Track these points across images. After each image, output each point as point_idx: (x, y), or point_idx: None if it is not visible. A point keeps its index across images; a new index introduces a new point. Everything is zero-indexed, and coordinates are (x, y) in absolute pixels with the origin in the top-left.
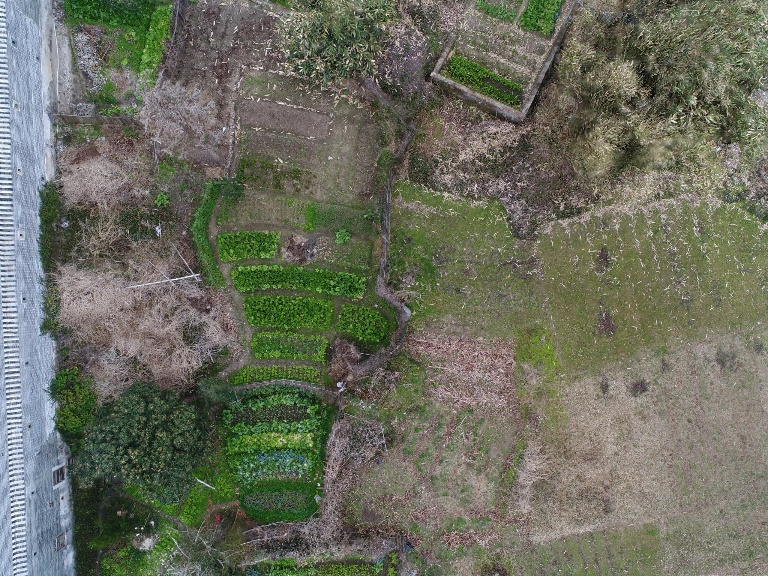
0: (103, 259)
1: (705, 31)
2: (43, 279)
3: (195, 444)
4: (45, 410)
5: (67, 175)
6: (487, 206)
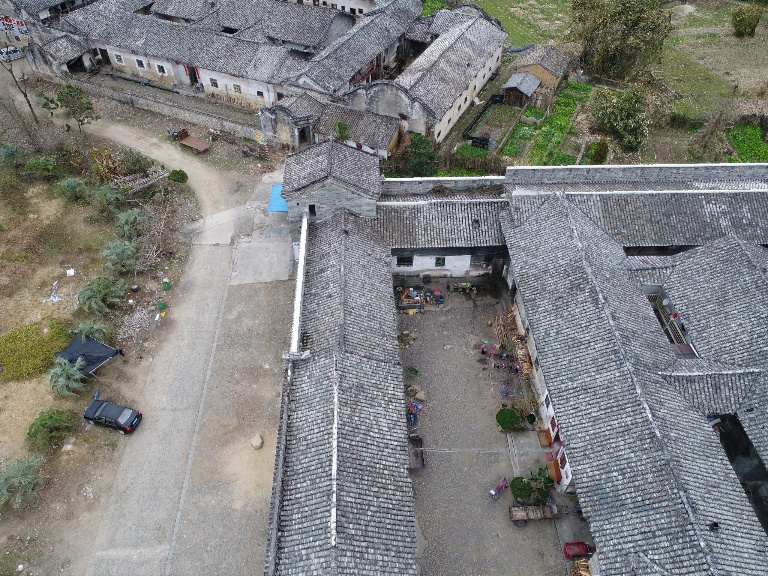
0: None
1: (628, 6)
2: None
3: None
4: None
5: None
6: (673, 104)
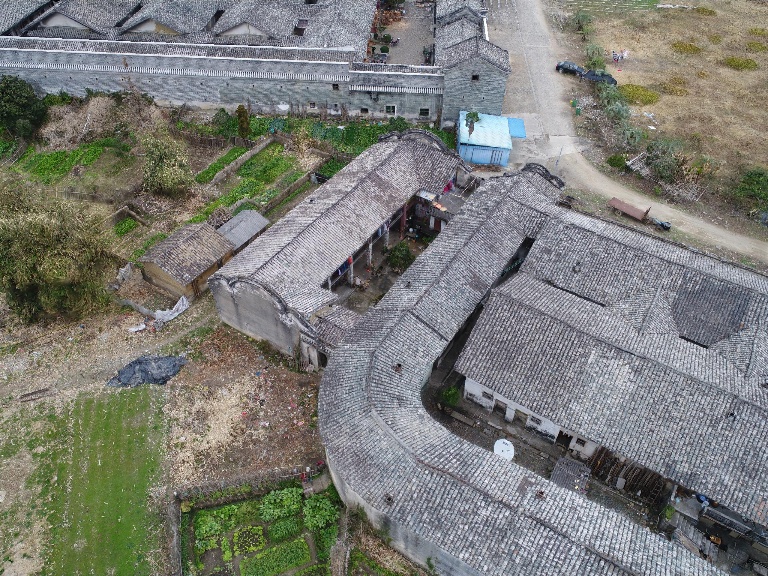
0: (114, 114)
1: None
2: (110, 92)
3: (1, 114)
4: (54, 88)
5: (156, 108)
6: None
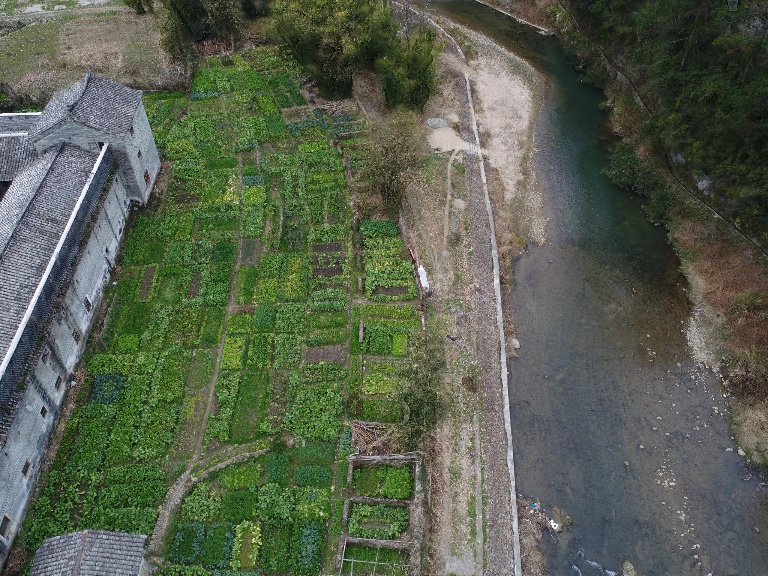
0: None
1: None
2: None
3: None
4: None
5: None
6: None
